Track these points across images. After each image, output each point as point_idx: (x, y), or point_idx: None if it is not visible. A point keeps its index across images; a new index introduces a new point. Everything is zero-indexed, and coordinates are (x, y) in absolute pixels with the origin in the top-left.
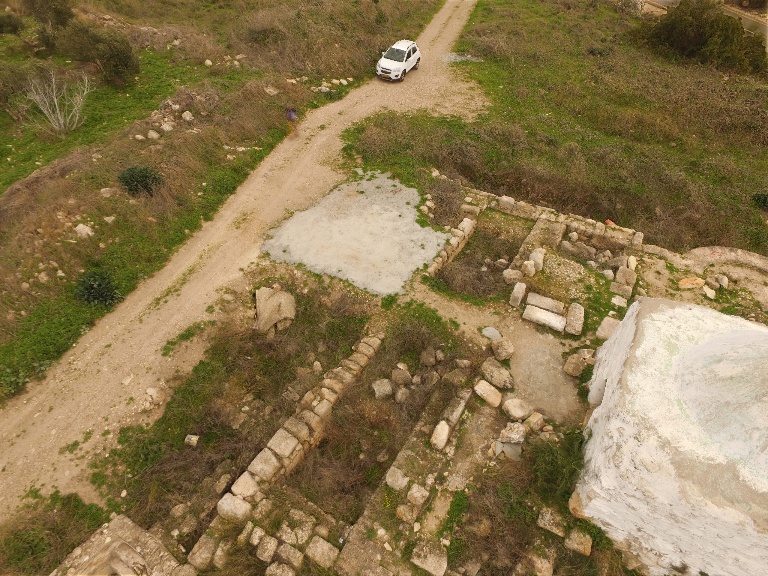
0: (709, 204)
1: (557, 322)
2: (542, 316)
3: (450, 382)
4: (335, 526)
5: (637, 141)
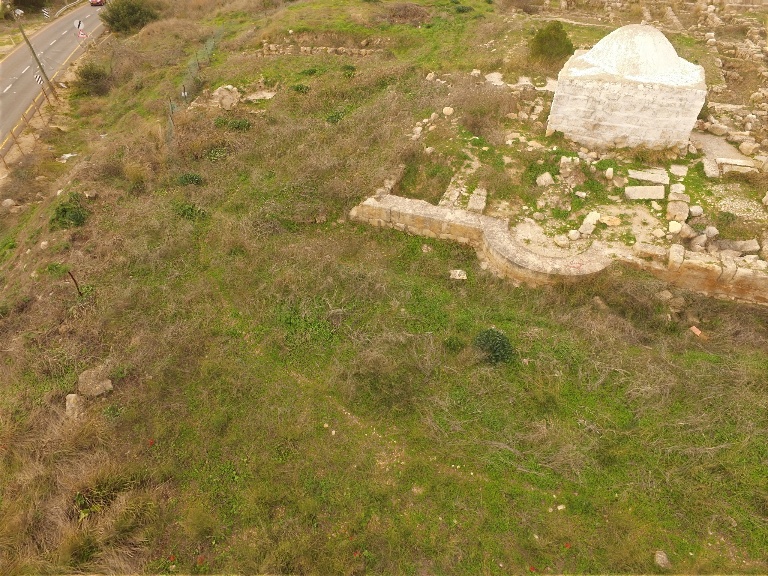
0: (581, 341)
1: (724, 159)
2: (738, 161)
3: (765, 136)
4: (761, 123)
5: (764, 571)
